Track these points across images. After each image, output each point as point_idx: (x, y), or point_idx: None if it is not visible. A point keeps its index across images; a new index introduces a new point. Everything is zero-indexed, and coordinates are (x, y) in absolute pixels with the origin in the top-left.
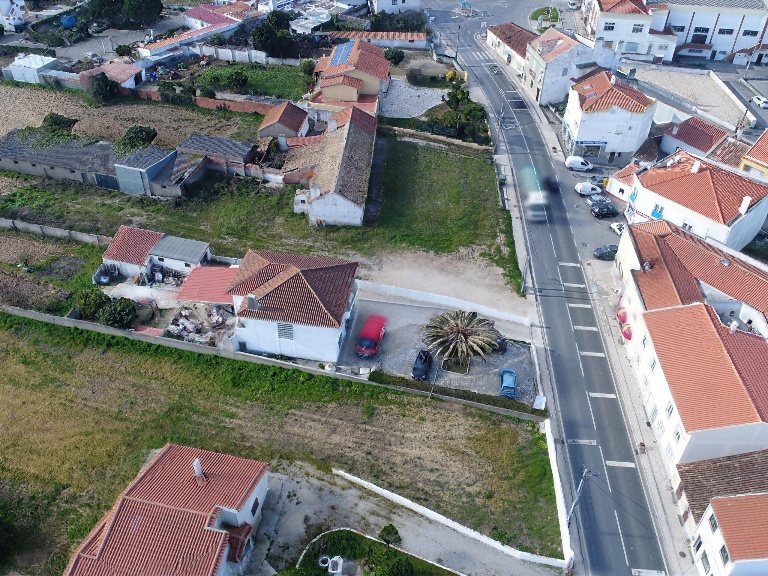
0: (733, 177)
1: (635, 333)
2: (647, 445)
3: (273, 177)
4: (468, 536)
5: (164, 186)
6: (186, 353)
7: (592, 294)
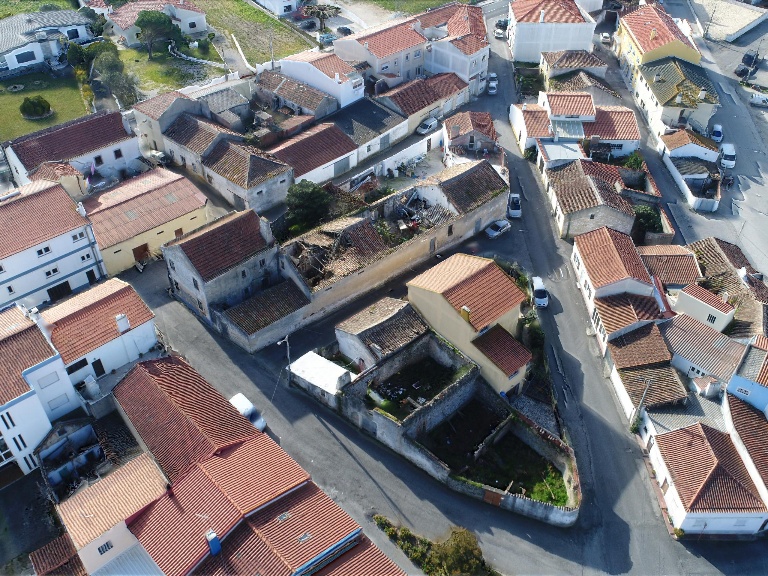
0: (562, 7)
1: None
2: None
3: None
4: None
5: None
6: (240, 0)
7: None
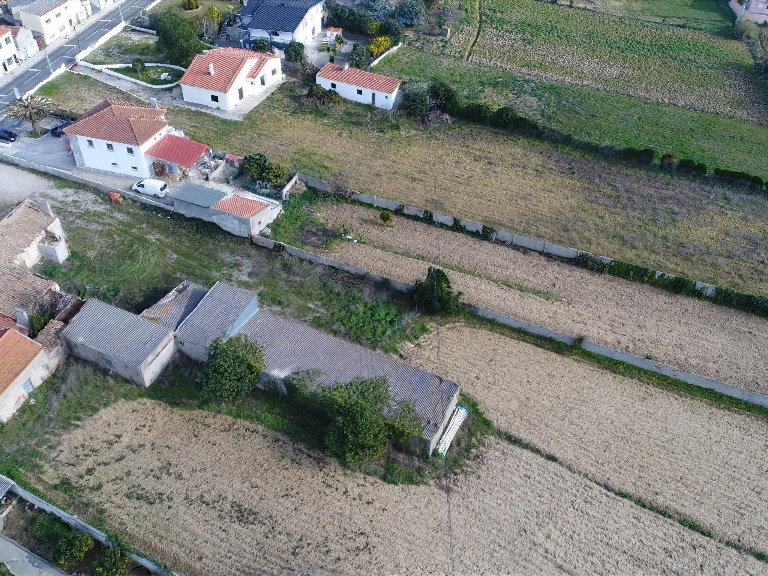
0: None
1: None
2: None
3: None
4: None
5: None
6: None
7: None
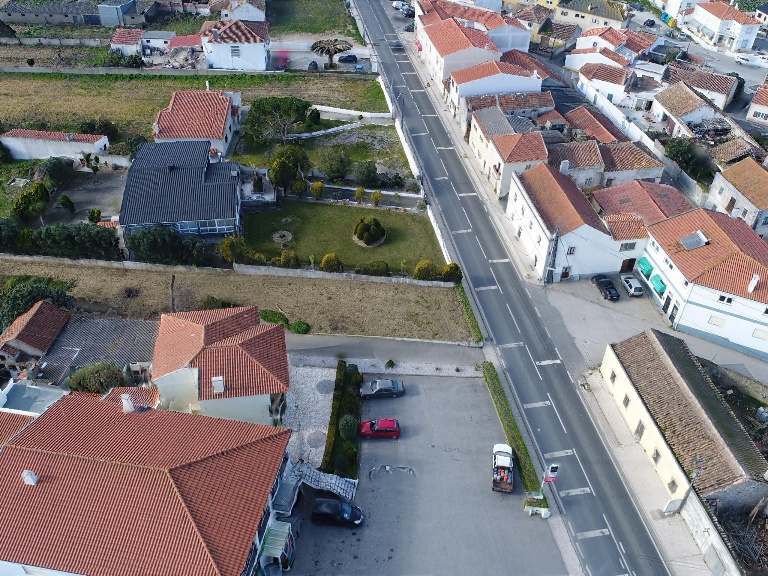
0: None
1: (423, 44)
2: (431, 85)
3: (203, 10)
4: (345, 114)
5: (133, 17)
6: (178, 76)
7: (403, 43)
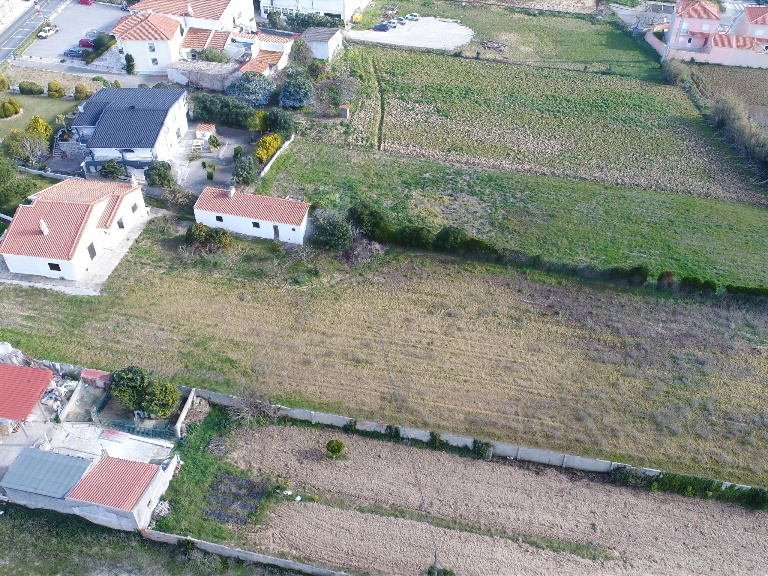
0: None
1: None
2: None
3: None
4: None
5: None
6: None
7: None
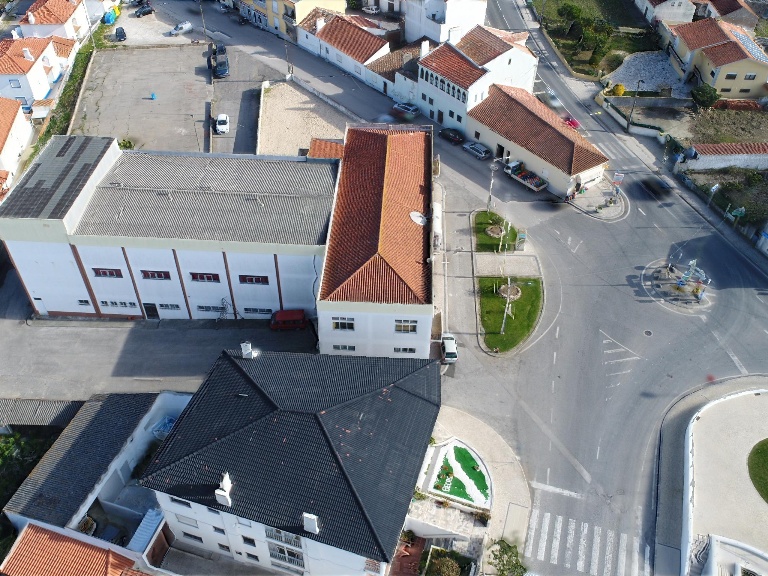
0: None
1: None
2: None
3: None
4: None
5: None
6: None
7: None
